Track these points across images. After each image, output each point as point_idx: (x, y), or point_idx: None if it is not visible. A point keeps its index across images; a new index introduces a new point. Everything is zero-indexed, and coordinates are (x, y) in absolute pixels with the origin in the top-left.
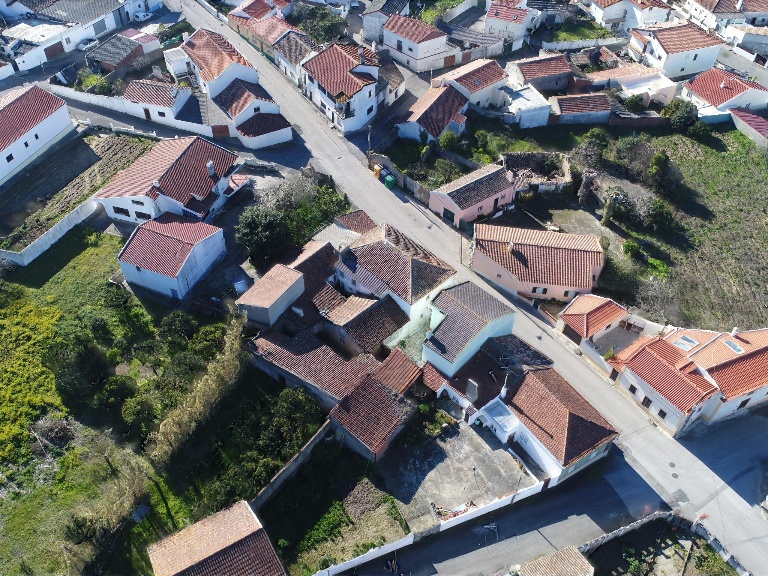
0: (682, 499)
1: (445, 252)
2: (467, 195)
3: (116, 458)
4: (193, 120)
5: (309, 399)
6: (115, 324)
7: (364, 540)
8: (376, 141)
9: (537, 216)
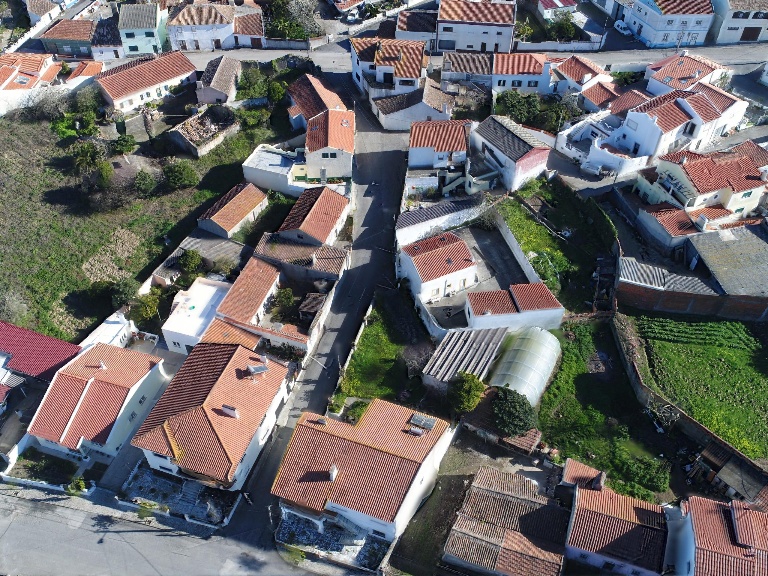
0: None
1: (205, 66)
2: (214, 65)
3: None
4: (425, 7)
5: None
6: None
7: None
8: (333, 82)
9: (176, 117)
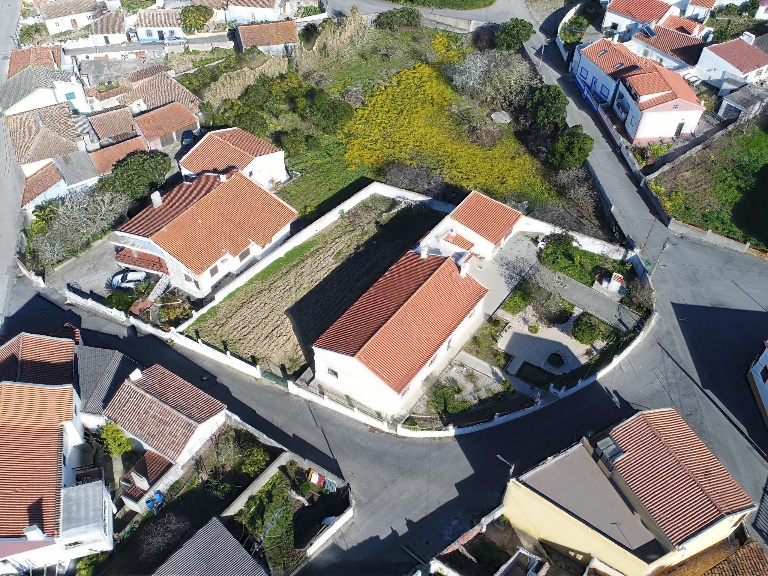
0: (7, 57)
1: None
2: None
3: (314, 86)
4: (134, 366)
5: (182, 78)
6: (302, 149)
7: (191, 56)
8: None
9: None
